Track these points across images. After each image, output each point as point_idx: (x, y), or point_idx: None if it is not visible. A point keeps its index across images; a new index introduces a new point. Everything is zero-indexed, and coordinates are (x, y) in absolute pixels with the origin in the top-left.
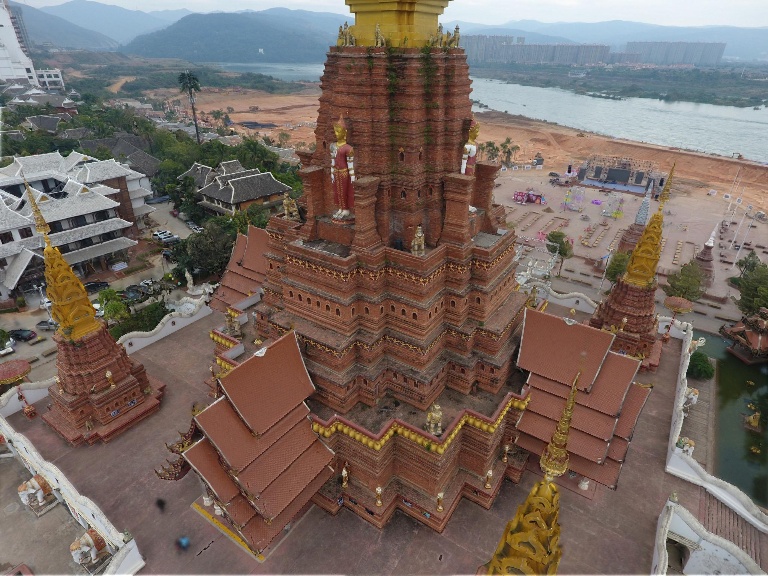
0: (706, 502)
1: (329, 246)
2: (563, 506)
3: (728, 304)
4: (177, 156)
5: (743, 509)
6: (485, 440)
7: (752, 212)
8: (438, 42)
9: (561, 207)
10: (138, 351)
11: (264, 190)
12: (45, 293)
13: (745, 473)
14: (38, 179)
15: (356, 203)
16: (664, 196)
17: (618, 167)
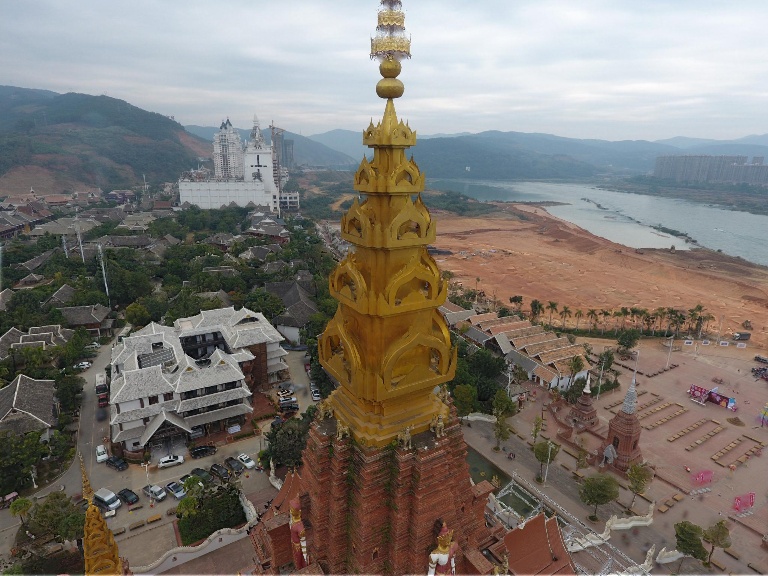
0: None
1: None
2: None
3: None
4: (329, 308)
5: None
6: None
7: None
8: (404, 443)
9: (757, 420)
10: (180, 565)
11: None
12: (169, 448)
13: None
14: (209, 332)
15: None
16: None
17: None
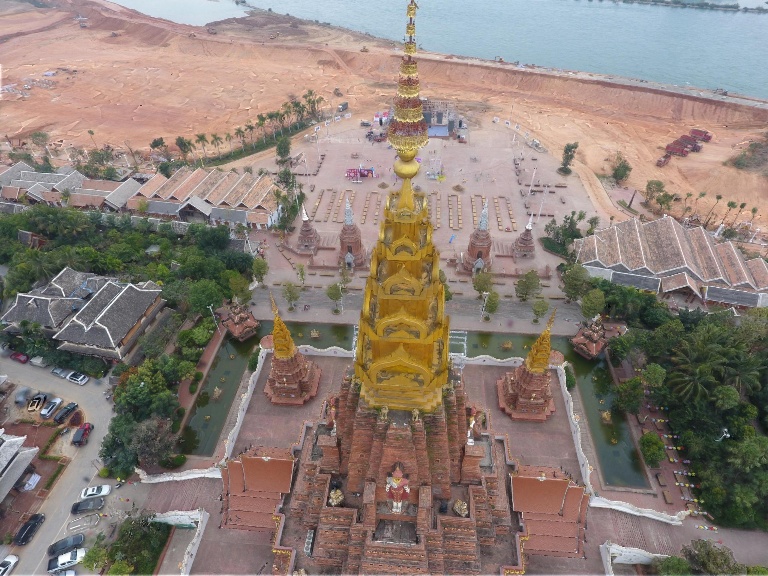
0: (614, 518)
1: (395, 529)
2: (555, 569)
3: (552, 279)
4: None
5: (630, 510)
6: (517, 575)
7: (529, 140)
8: (451, 390)
9: (393, 178)
10: None
11: (136, 310)
12: None
13: (615, 463)
14: None
15: (420, 511)
16: (551, 325)
17: None
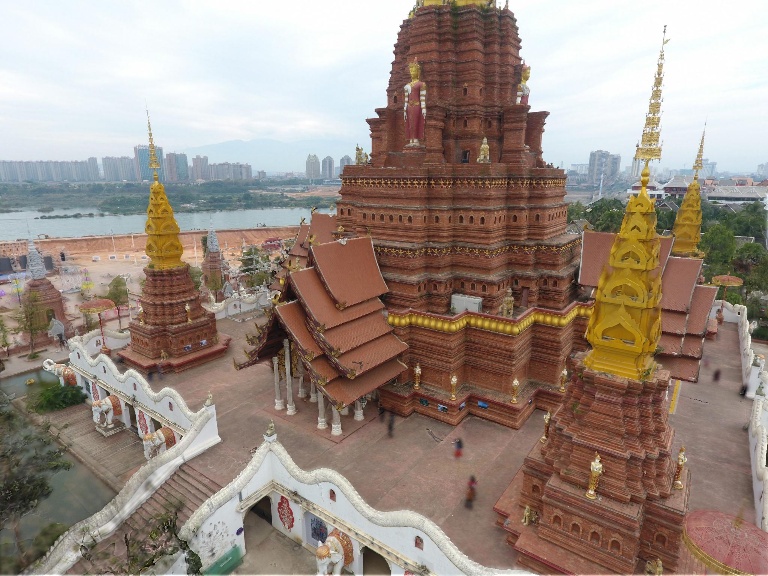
0: None
1: None
2: None
3: None
4: None
5: None
6: None
7: None
8: None
9: (13, 302)
10: None
11: None
12: None
13: None
14: None
15: None
16: None
17: None
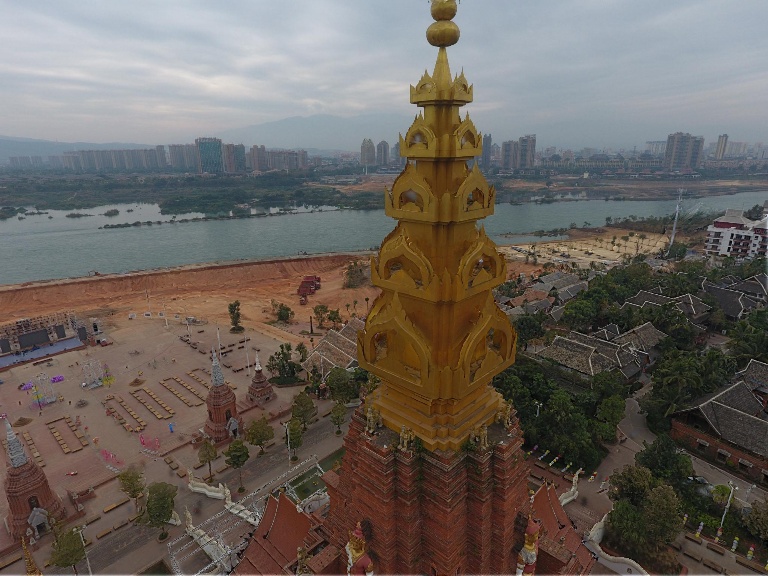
0: None
1: None
2: None
3: None
4: None
5: None
6: None
7: (183, 320)
8: None
9: (33, 408)
10: None
11: None
12: None
13: None
14: None
15: None
16: None
17: (28, 331)
